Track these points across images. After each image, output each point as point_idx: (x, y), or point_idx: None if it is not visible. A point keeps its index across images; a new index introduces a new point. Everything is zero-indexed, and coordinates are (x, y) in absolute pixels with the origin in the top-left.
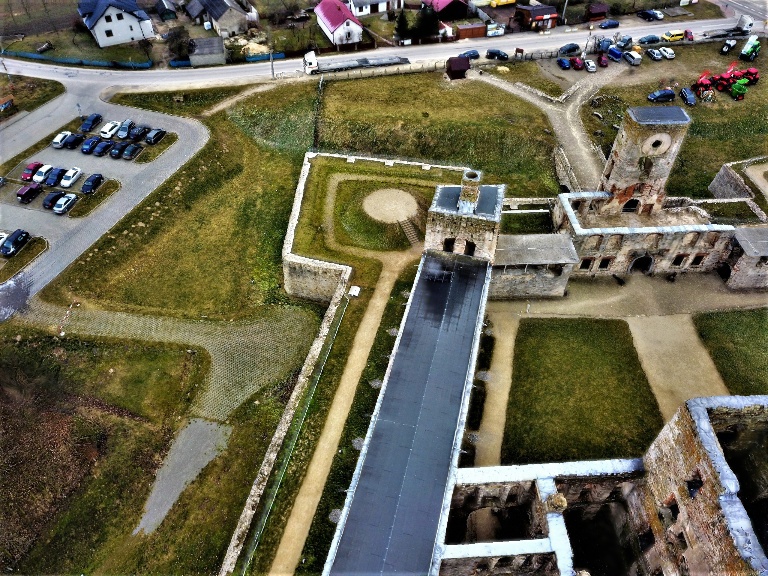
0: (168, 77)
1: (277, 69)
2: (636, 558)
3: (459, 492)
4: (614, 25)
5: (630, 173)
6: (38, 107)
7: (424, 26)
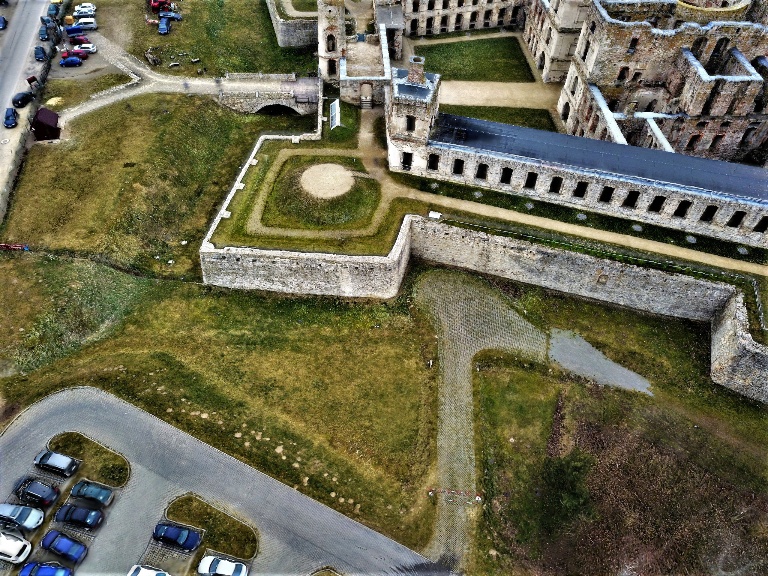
0: None
1: None
2: None
3: None
4: (4, 21)
5: None
6: None
7: None
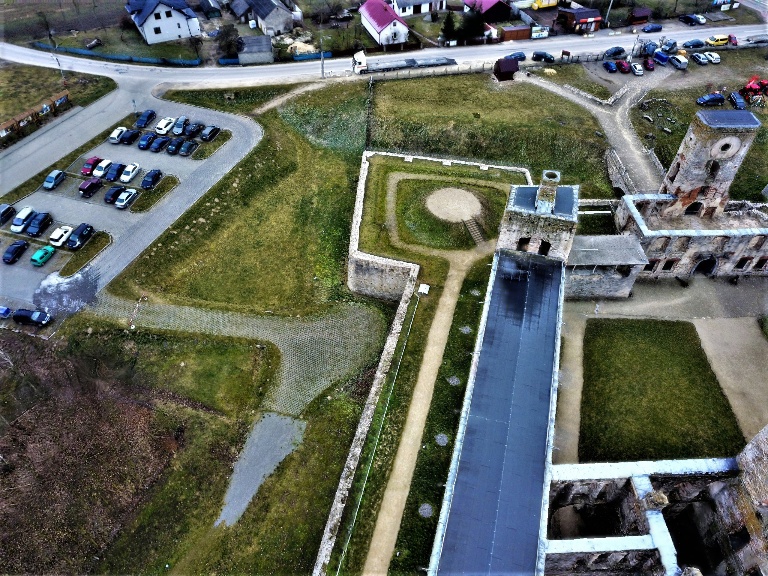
0: (218, 75)
1: (325, 68)
2: (725, 557)
3: (553, 488)
4: (657, 29)
5: (696, 176)
6: (92, 103)
7: (470, 27)
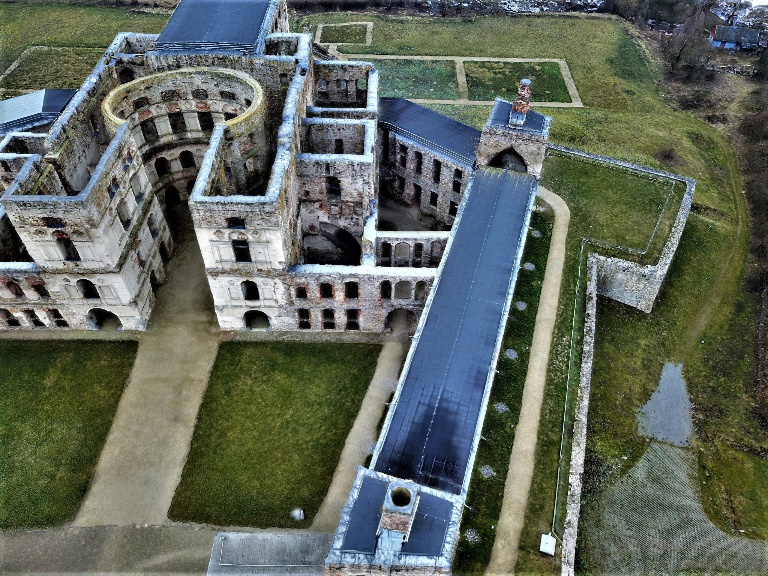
0: None
1: None
2: None
3: None
4: None
5: None
6: None
7: None
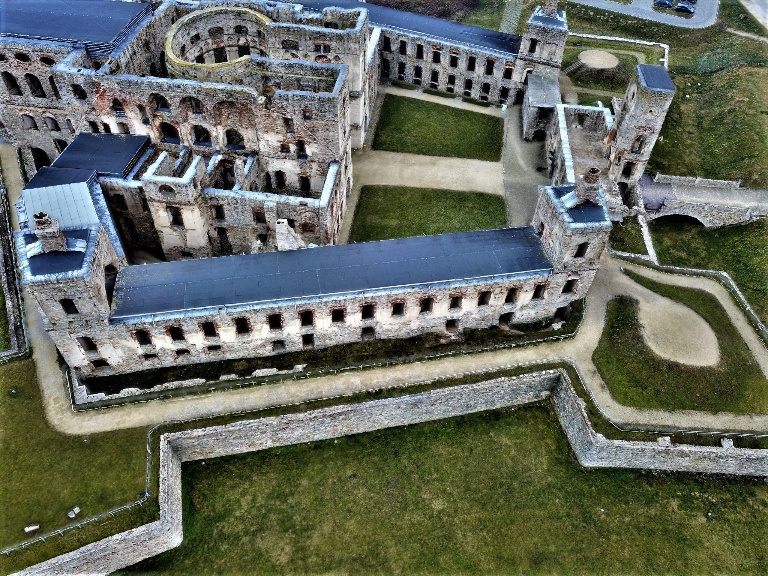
0: None
1: None
2: None
3: None
4: None
5: None
6: None
7: None
